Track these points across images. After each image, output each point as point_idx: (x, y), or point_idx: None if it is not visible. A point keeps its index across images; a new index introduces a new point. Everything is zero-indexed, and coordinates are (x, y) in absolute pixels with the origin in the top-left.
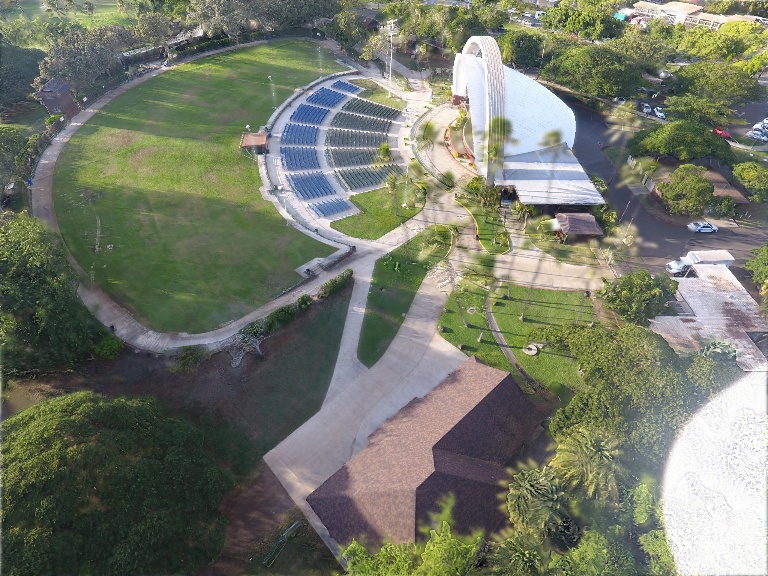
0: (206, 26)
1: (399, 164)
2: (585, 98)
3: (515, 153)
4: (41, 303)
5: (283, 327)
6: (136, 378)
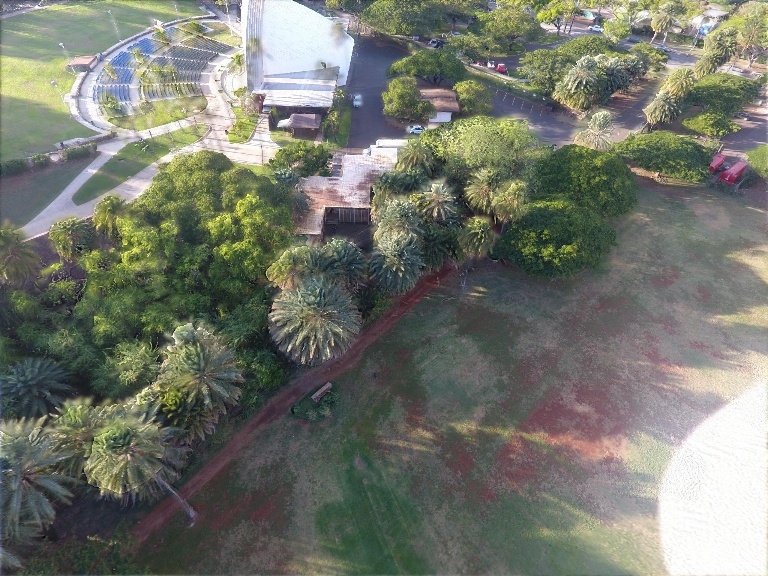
0: None
1: (203, 84)
2: (400, 40)
3: (286, 72)
4: None
5: (18, 175)
6: None
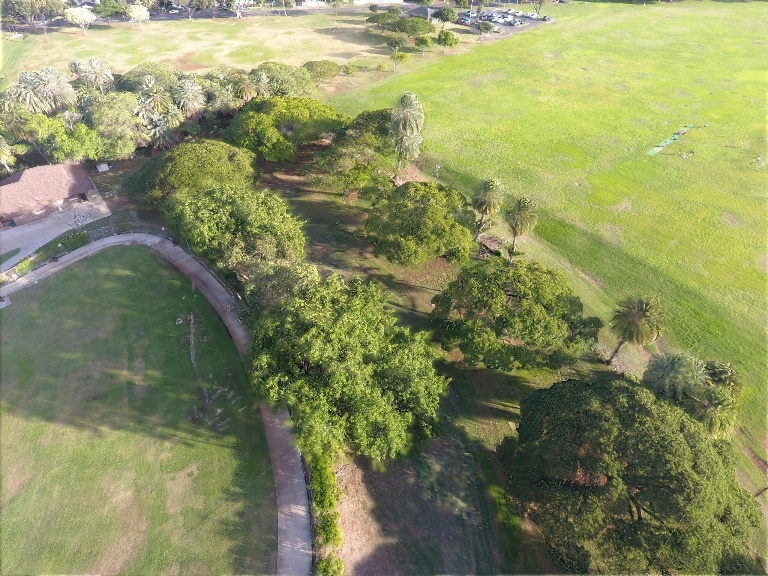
0: None
1: None
2: None
3: None
4: None
5: None
6: None
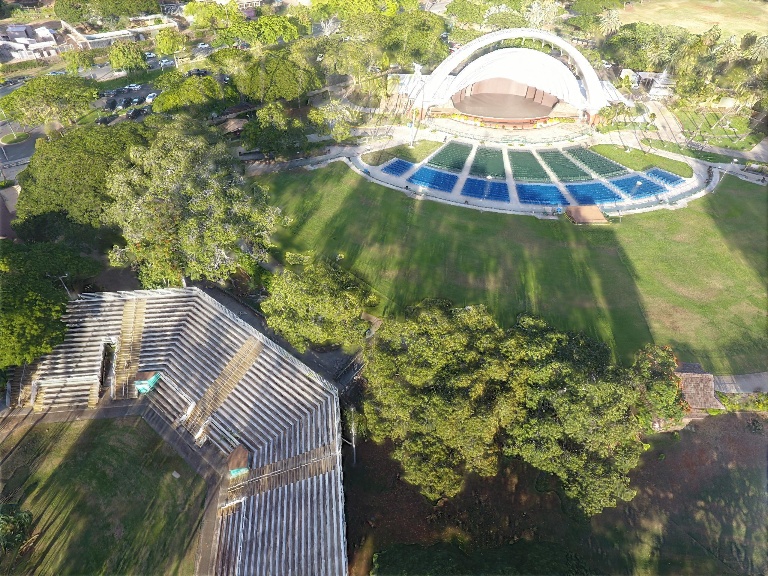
0: None
1: (561, 151)
2: None
3: None
4: None
5: None
6: None
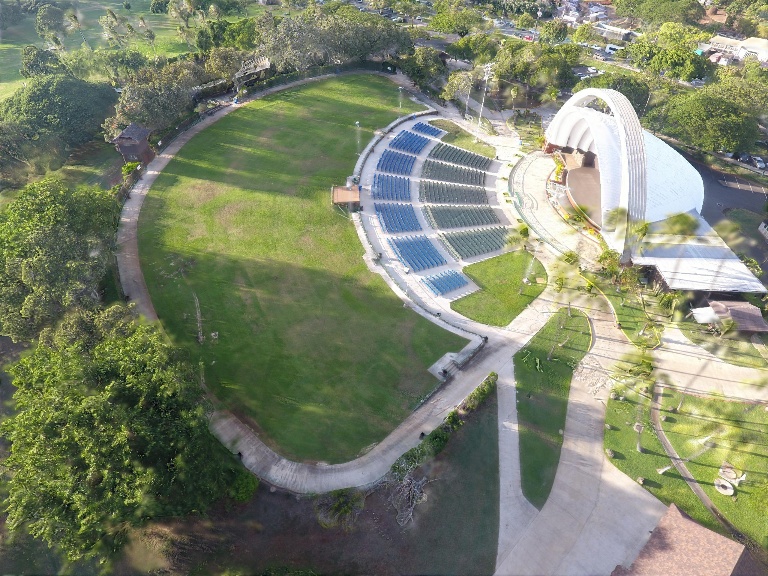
0: (274, 58)
1: (506, 226)
2: (690, 149)
3: (645, 222)
4: (176, 445)
5: None
6: (275, 527)
